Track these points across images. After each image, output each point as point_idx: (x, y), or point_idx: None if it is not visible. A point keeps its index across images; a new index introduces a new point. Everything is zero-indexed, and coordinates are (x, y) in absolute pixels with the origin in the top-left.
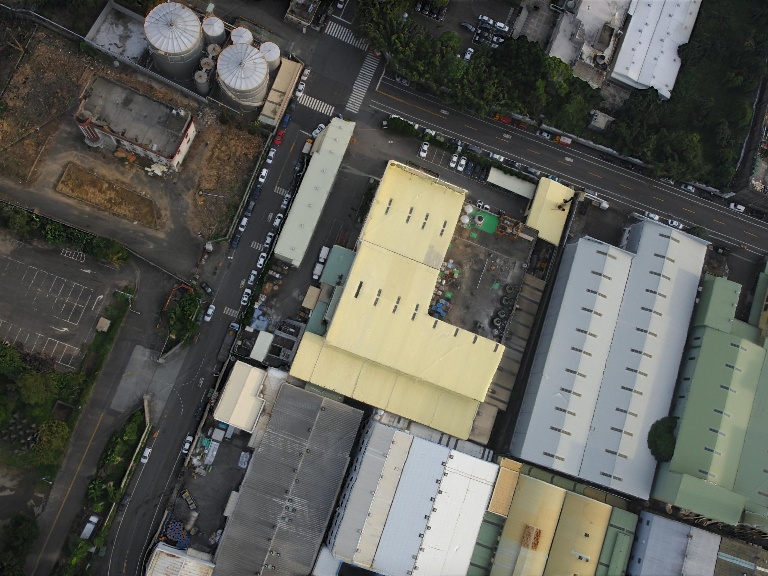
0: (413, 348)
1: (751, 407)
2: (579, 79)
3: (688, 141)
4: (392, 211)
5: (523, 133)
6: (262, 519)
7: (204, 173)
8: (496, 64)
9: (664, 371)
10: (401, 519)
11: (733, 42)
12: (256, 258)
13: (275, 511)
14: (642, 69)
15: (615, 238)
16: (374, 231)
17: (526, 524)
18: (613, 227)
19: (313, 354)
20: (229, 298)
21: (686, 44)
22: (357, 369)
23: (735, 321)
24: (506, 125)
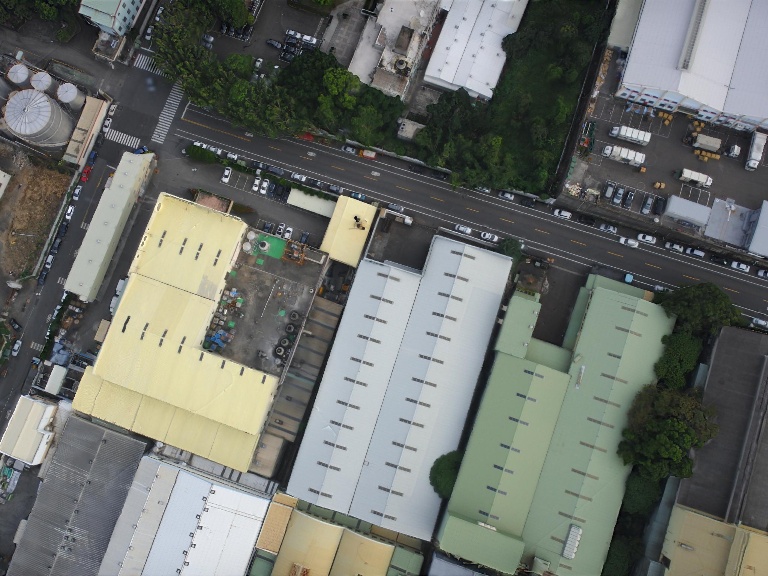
0: (181, 381)
1: (549, 441)
2: (372, 89)
3: (487, 146)
4: (166, 243)
5: (328, 149)
6: (44, 548)
7: (17, 214)
8: (284, 82)
9: (453, 401)
10: (162, 553)
11: (555, 28)
12: (61, 293)
13: (56, 540)
14: (458, 69)
15: (422, 255)
16: (149, 264)
17: (293, 562)
18: (420, 244)
19: (91, 388)
20: (36, 333)
21: (507, 36)
22: (136, 402)
23: (542, 344)
24: (311, 142)
